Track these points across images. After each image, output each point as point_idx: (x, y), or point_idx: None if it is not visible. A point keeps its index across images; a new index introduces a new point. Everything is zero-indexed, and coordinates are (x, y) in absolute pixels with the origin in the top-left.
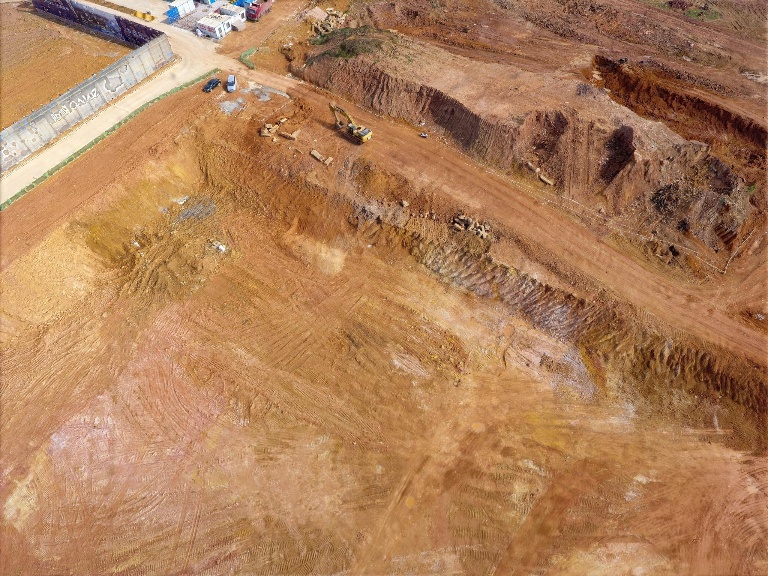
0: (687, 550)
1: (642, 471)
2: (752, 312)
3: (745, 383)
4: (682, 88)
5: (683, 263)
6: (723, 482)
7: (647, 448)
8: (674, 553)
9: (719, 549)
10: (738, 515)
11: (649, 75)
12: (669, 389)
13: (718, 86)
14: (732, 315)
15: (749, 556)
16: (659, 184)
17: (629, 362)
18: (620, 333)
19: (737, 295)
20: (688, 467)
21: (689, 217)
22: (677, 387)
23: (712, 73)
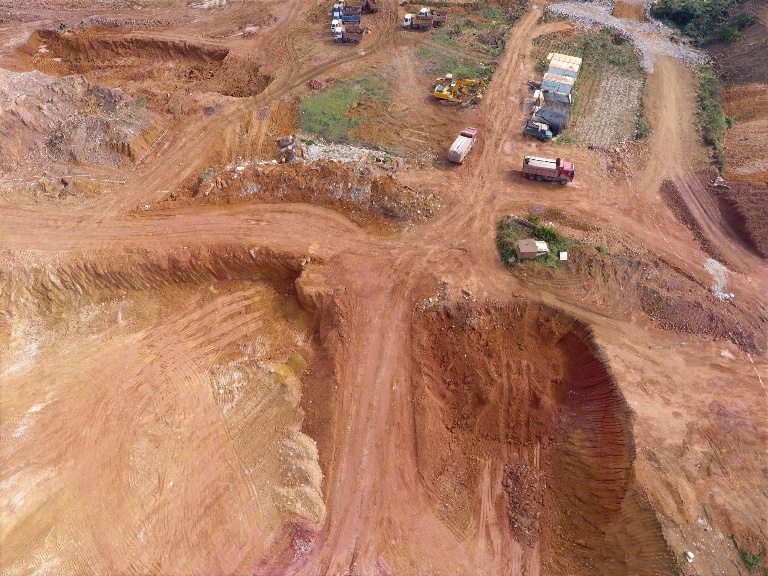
0: (74, 448)
1: (37, 400)
2: (142, 206)
3: (128, 271)
4: (121, 34)
5: (73, 190)
6: (120, 367)
7: (46, 376)
8: (60, 459)
9: (107, 429)
10: (131, 388)
11: (88, 32)
12: (78, 310)
13: (157, 22)
14: (120, 217)
15: (136, 418)
16: (49, 128)
17: (32, 305)
18: (5, 283)
19: (132, 197)
20: (88, 371)
21: (73, 147)
22: (86, 304)
23: (159, 13)
